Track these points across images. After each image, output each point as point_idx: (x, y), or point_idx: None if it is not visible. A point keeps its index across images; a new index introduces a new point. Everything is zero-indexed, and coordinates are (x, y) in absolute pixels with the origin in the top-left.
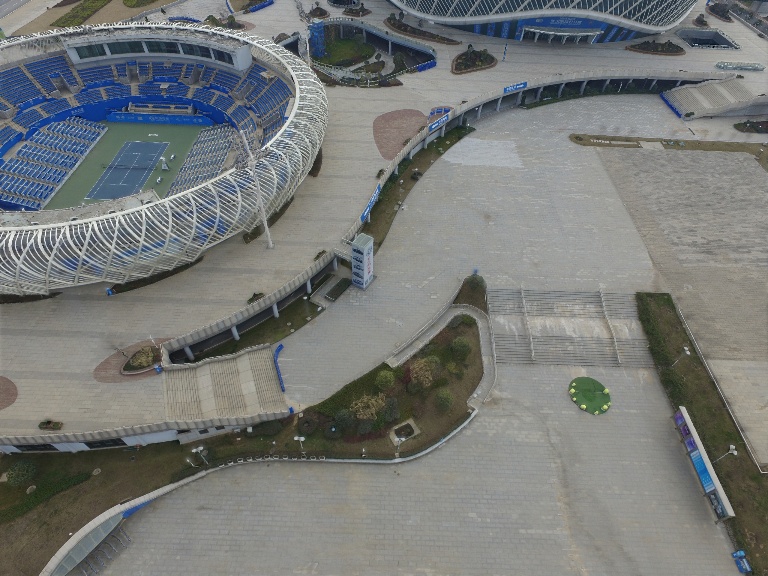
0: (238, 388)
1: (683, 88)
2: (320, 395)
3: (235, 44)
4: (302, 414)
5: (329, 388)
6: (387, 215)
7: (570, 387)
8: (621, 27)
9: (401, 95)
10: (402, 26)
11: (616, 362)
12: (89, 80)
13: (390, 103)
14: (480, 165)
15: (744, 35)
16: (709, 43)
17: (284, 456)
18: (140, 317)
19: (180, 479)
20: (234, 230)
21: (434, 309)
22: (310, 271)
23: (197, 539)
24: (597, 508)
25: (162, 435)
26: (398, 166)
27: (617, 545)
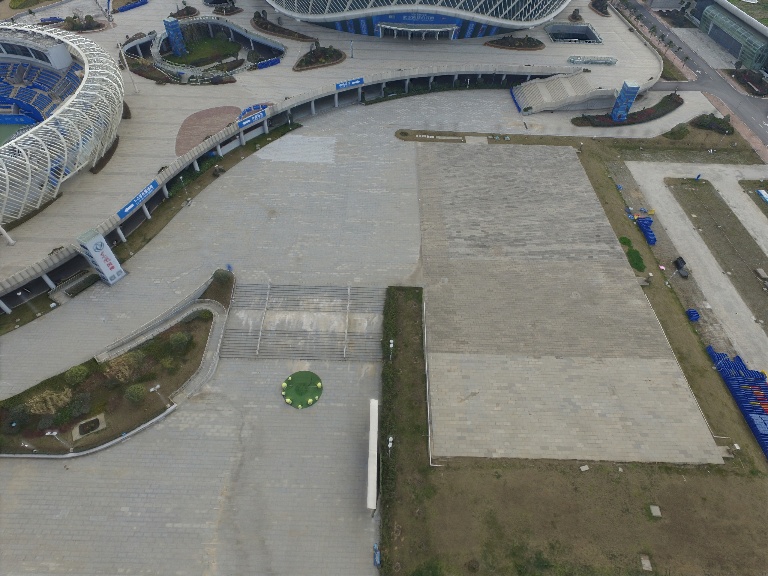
0: None
1: (532, 83)
2: (13, 390)
3: (50, 43)
4: None
5: (26, 383)
6: (170, 211)
7: (285, 381)
8: (478, 22)
9: (228, 92)
10: (264, 24)
11: None
12: None
13: (212, 100)
14: (290, 161)
15: (615, 29)
16: (583, 38)
17: None
18: None
19: None
20: None
21: (172, 304)
22: (38, 267)
23: None
24: (257, 502)
25: None
26: (203, 163)
27: (260, 539)
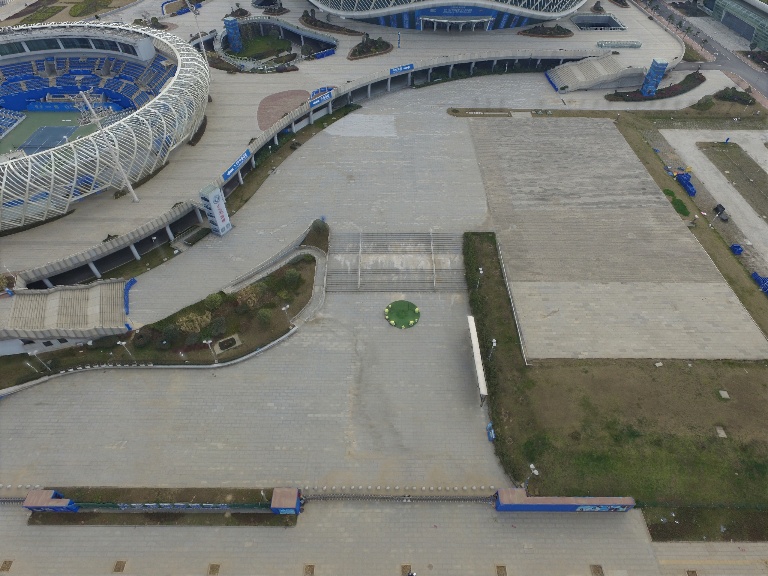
0: (84, 310)
1: (565, 66)
2: (158, 316)
3: (137, 37)
4: (138, 331)
5: (168, 311)
6: (260, 178)
7: (387, 308)
8: (511, 14)
9: (294, 78)
10: (313, 21)
11: (433, 288)
12: (10, 75)
13: (281, 85)
14: (357, 135)
15: (635, 18)
16: None
17: (117, 363)
18: (7, 256)
19: (24, 382)
20: (100, 185)
21: (279, 250)
22: (165, 218)
23: (30, 426)
24: (381, 397)
25: (11, 346)
26: (280, 138)
27: (389, 424)
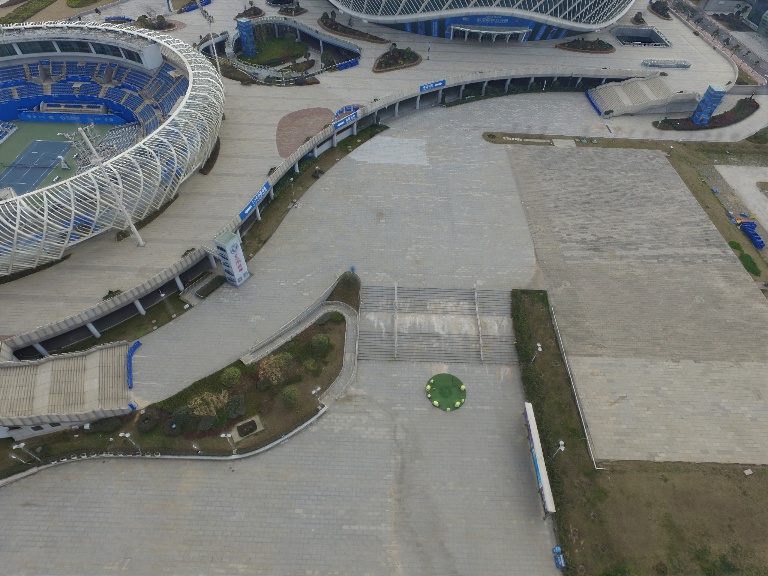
0: (80, 385)
1: (608, 86)
2: (167, 392)
3: (143, 43)
4: (144, 411)
5: (178, 385)
6: (279, 213)
7: (428, 384)
8: (550, 25)
9: (315, 93)
10: (333, 25)
11: (480, 359)
12: (0, 80)
13: (302, 101)
14: (385, 163)
15: (680, 33)
16: (646, 41)
17: (119, 453)
18: None
19: (9, 476)
20: (100, 228)
21: (303, 306)
22: (174, 268)
23: (14, 535)
24: (427, 504)
25: None
26: (301, 164)
27: (439, 541)
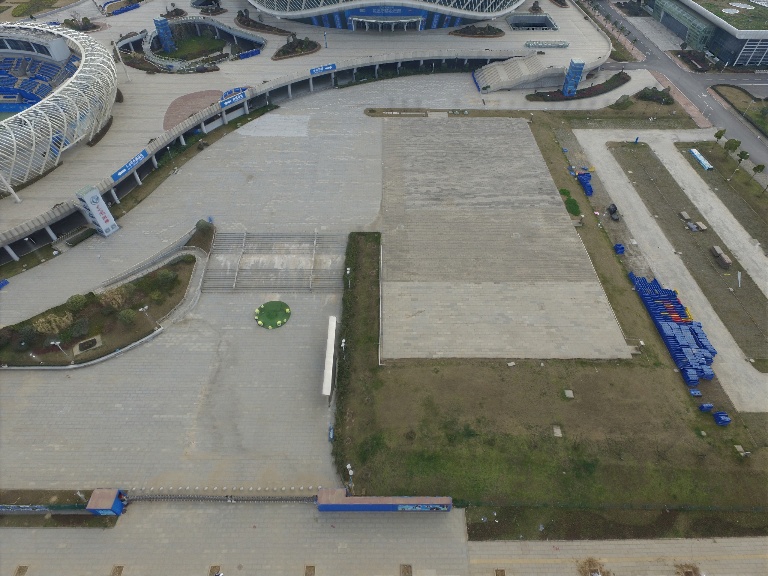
0: None
1: (492, 66)
2: (22, 318)
3: (50, 37)
4: None
5: (33, 312)
6: (159, 178)
7: (258, 309)
8: (442, 14)
9: (212, 79)
10: (246, 21)
11: None
12: None
13: (198, 86)
14: (267, 136)
15: (571, 18)
16: None
17: None
18: None
19: None
20: None
21: None
22: (42, 219)
23: None
24: (231, 398)
25: None
26: (188, 139)
27: (233, 424)
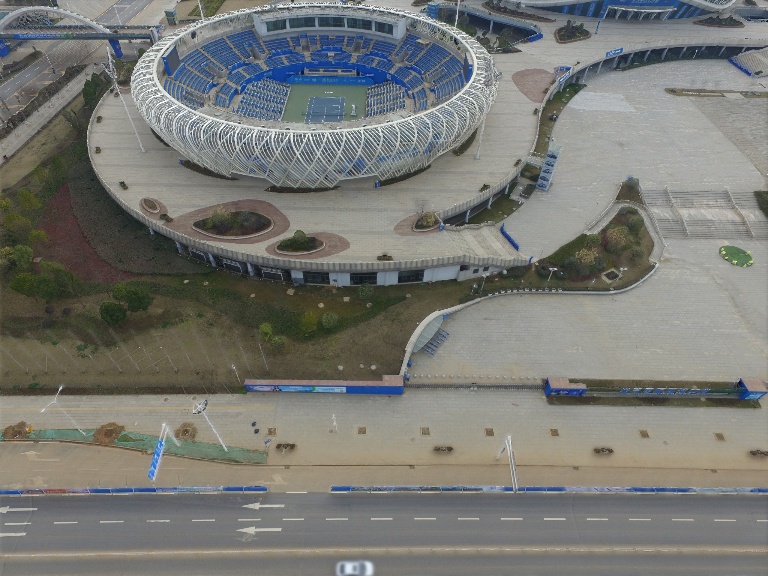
0: (490, 245)
1: (748, 53)
2: (545, 253)
3: (395, 17)
4: (538, 263)
5: (549, 249)
6: (542, 144)
7: (720, 251)
8: (690, 5)
9: (524, 59)
10: (501, 8)
11: (749, 236)
12: (272, 49)
13: (518, 64)
14: (601, 110)
15: None
16: None
17: (533, 289)
18: (407, 200)
19: (466, 302)
20: (455, 143)
21: (605, 202)
22: (515, 172)
23: (492, 335)
24: (763, 318)
25: (449, 272)
26: None
27: None
